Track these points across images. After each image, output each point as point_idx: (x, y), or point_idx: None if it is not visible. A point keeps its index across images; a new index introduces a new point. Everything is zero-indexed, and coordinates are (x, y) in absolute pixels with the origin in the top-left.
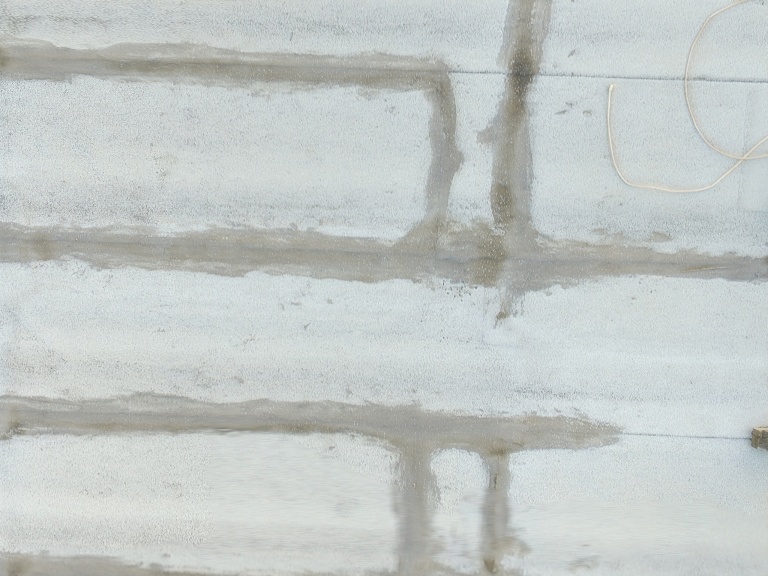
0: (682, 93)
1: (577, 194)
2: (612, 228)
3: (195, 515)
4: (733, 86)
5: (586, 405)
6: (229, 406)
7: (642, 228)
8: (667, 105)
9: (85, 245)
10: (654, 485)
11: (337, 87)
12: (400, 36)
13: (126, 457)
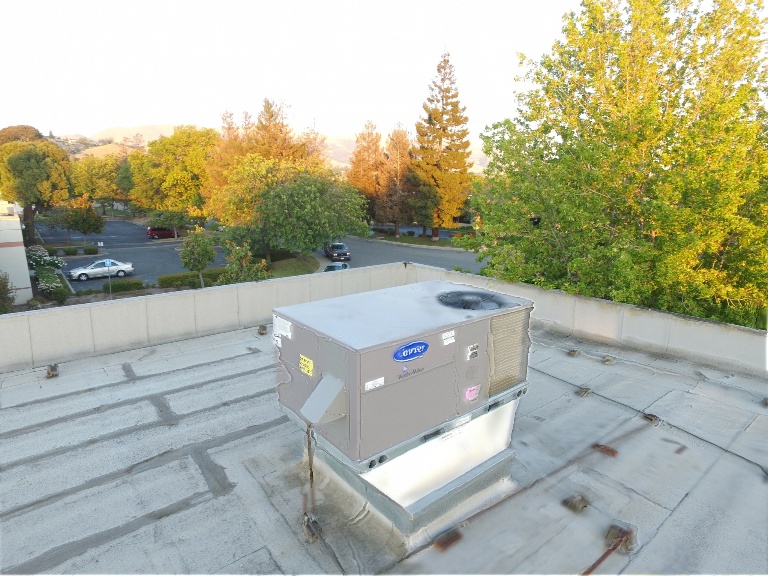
0: None
1: None
2: None
3: None
4: None
5: None
6: None
7: None
8: None
9: None
10: None
11: None
12: None
13: None
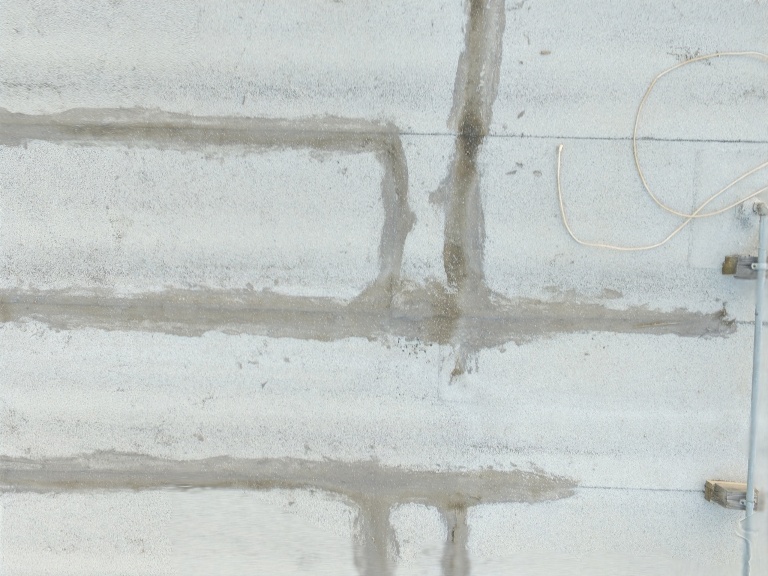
0: (631, 152)
1: (529, 252)
2: (564, 285)
3: (157, 570)
4: (681, 145)
5: (541, 459)
6: (189, 463)
7: (594, 285)
8: (616, 164)
9: (43, 307)
10: (610, 537)
11: (290, 149)
12: (351, 99)
13: (88, 514)
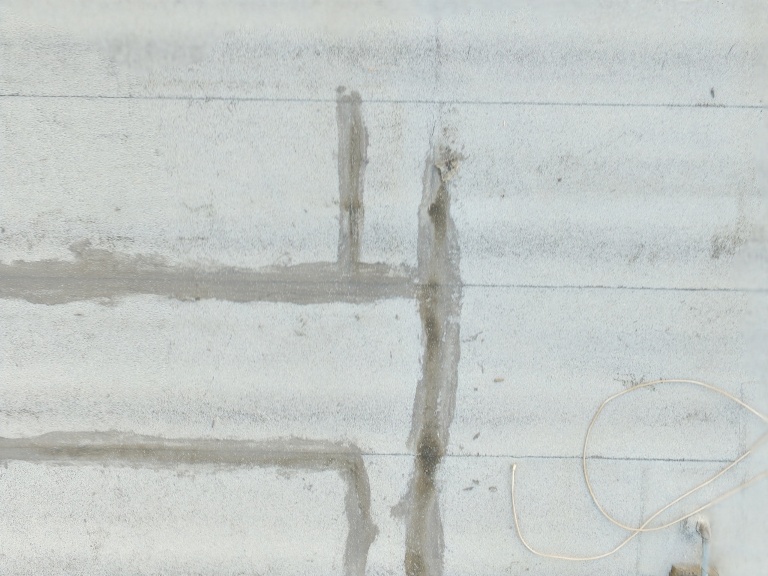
0: (581, 470)
1: (486, 561)
2: None
3: None
4: (628, 464)
5: None
6: None
7: None
8: (568, 480)
9: None
10: None
11: (258, 468)
12: (315, 422)
13: None
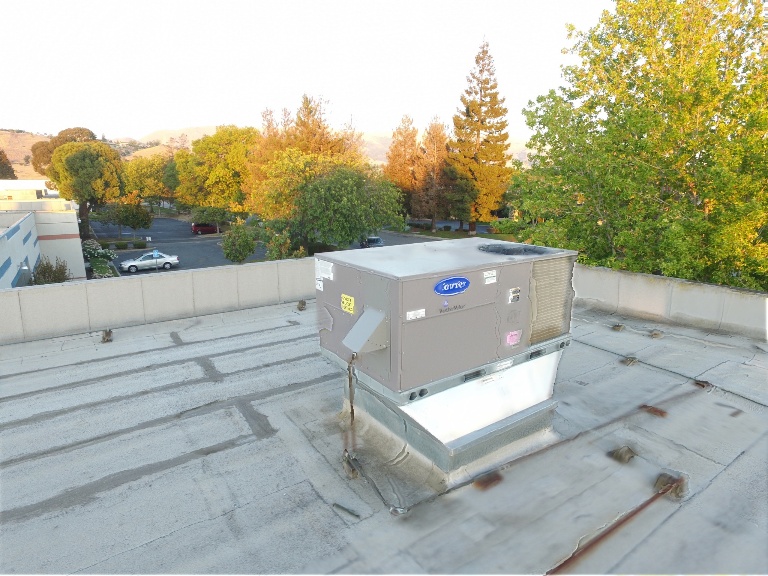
0: None
1: None
2: None
3: None
4: None
5: None
6: (45, 392)
7: None
8: None
9: None
10: None
11: None
12: None
13: None
